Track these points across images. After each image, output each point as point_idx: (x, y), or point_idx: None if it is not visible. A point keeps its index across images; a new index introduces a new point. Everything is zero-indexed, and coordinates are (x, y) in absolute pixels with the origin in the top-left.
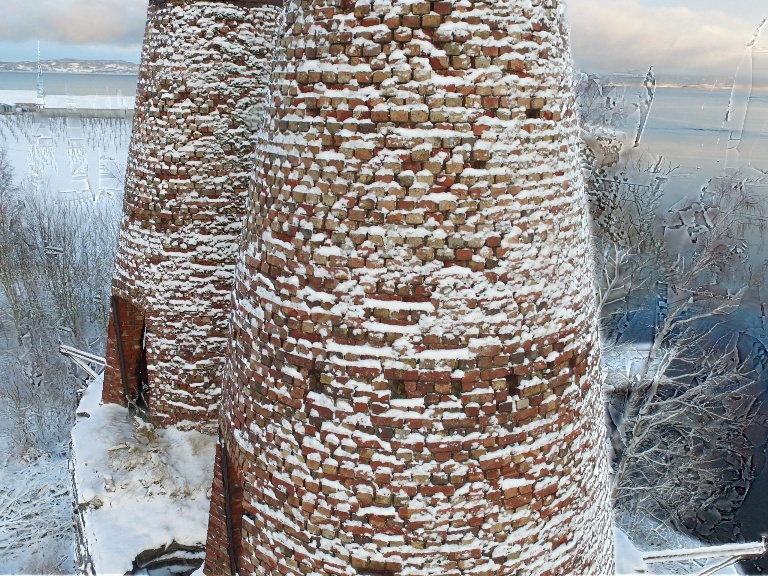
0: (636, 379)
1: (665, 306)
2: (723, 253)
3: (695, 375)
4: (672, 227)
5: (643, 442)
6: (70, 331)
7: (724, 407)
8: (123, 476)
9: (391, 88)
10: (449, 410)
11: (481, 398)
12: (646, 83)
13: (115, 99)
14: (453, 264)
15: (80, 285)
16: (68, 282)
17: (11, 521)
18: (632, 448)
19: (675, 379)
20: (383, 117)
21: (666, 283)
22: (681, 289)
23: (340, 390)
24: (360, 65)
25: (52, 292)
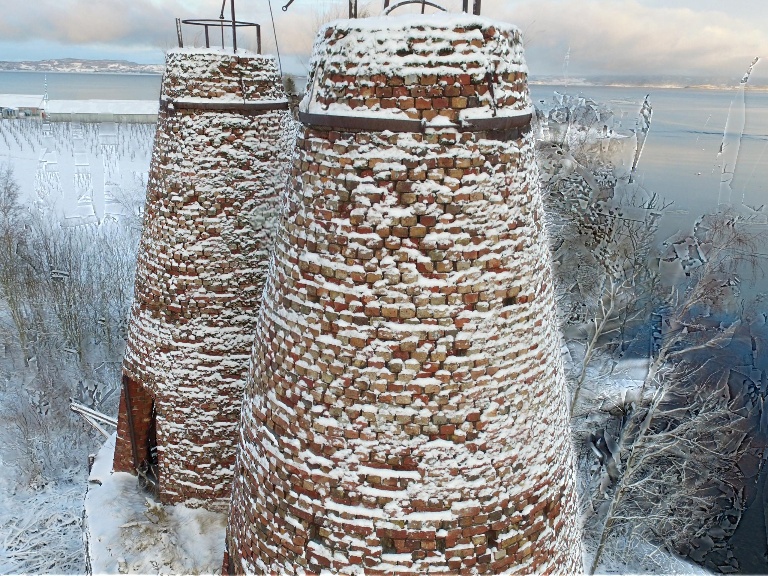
0: (631, 407)
1: (659, 337)
2: (715, 289)
3: (688, 409)
4: (666, 260)
5: (637, 473)
6: (75, 353)
7: (715, 442)
8: (135, 557)
9: (382, 289)
10: (434, 564)
11: (463, 553)
12: (643, 111)
13: (120, 125)
14: (438, 437)
15: (85, 308)
16: (73, 305)
17: (20, 552)
18: (626, 479)
19: (668, 413)
20: (375, 312)
21: (660, 315)
22: (675, 321)
23: (337, 543)
24: (355, 266)
25: (58, 315)
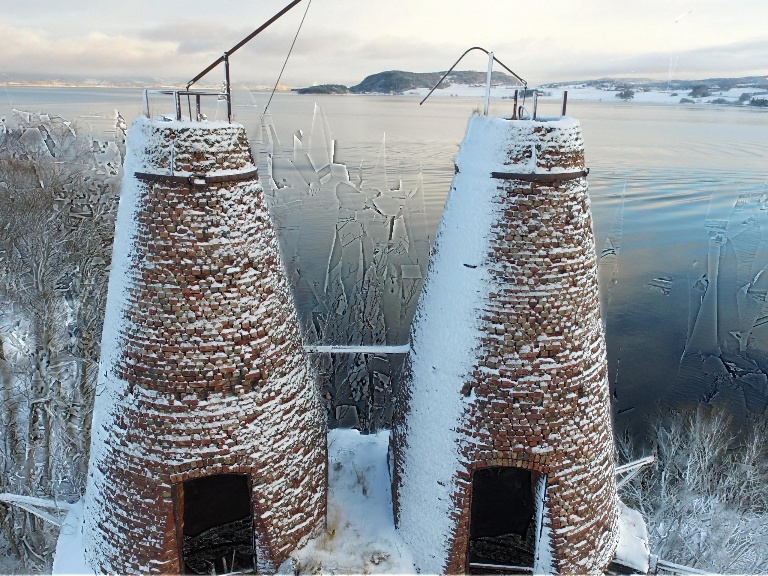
0: None
1: None
2: None
3: None
4: None
5: None
6: None
7: None
8: None
9: None
10: None
11: None
12: (119, 125)
13: None
14: None
15: None
16: None
17: None
18: None
19: None
20: None
21: None
22: None
23: None
24: None
25: None
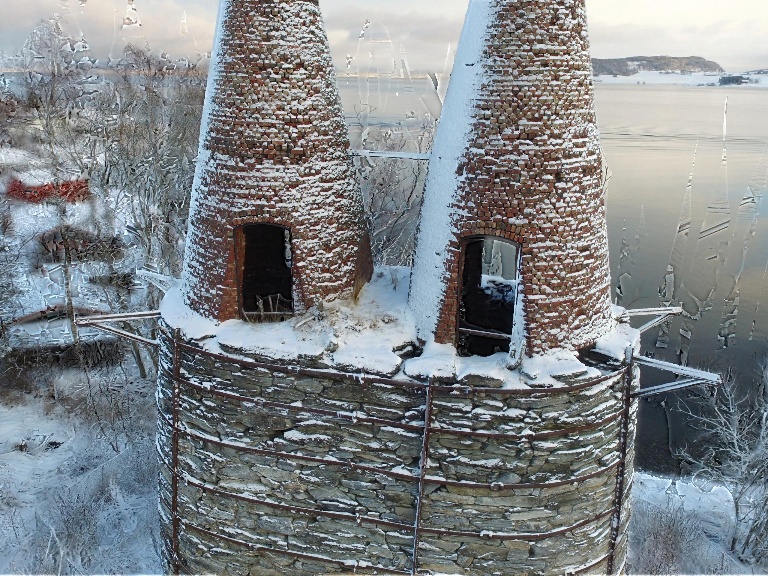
0: None
1: None
2: None
3: None
4: None
5: None
6: None
7: None
8: None
9: None
10: None
11: None
12: None
13: None
14: None
15: None
16: None
17: None
18: None
19: None
20: None
21: None
22: None
23: None
24: (563, 46)
25: None
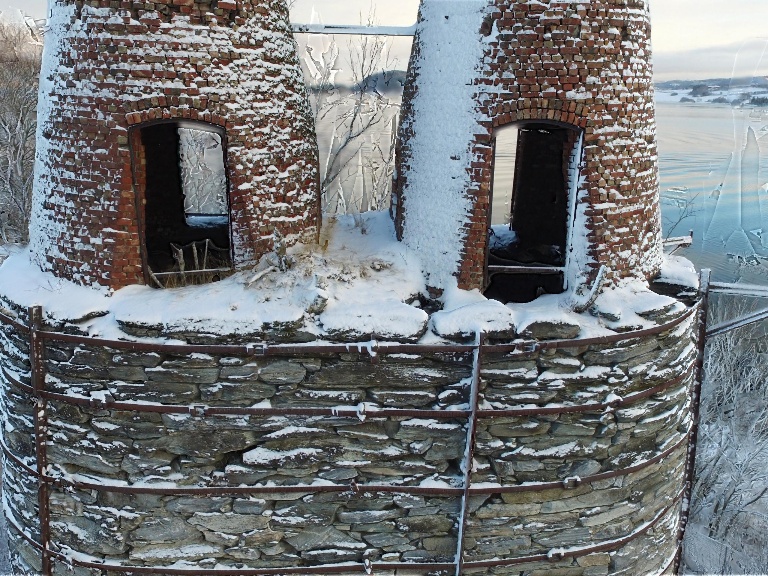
0: None
1: None
2: None
3: None
4: (211, 147)
5: None
6: None
7: None
8: None
9: None
10: None
11: None
12: None
13: None
14: None
15: None
16: None
17: None
18: None
19: None
20: None
21: None
22: None
23: None
24: None
25: None
